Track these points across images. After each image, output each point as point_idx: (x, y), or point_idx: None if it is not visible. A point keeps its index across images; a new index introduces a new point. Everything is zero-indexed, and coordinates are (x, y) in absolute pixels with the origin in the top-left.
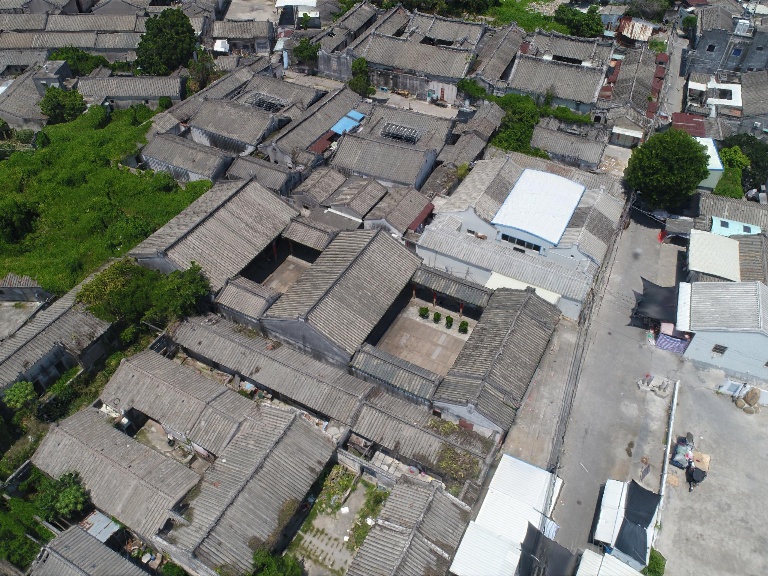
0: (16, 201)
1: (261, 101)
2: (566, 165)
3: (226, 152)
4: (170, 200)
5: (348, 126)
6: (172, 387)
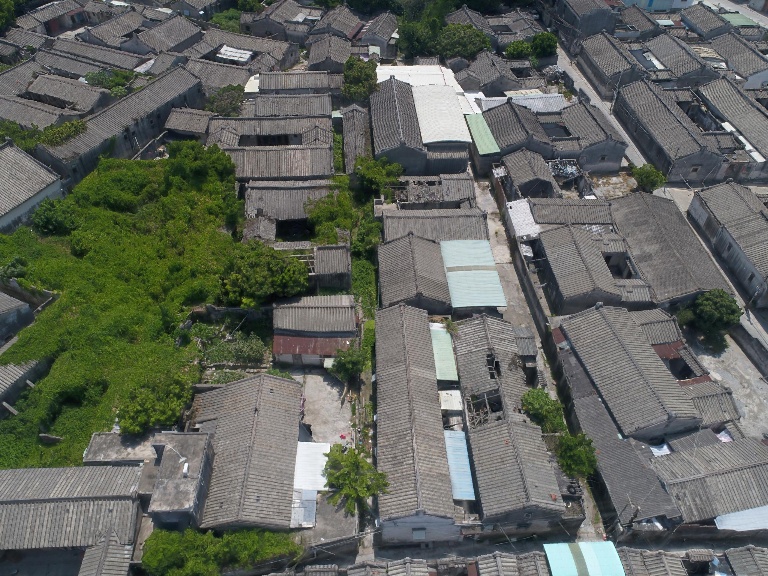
0: (166, 211)
1: None
2: None
3: None
4: (6, 240)
5: None
6: (31, 105)
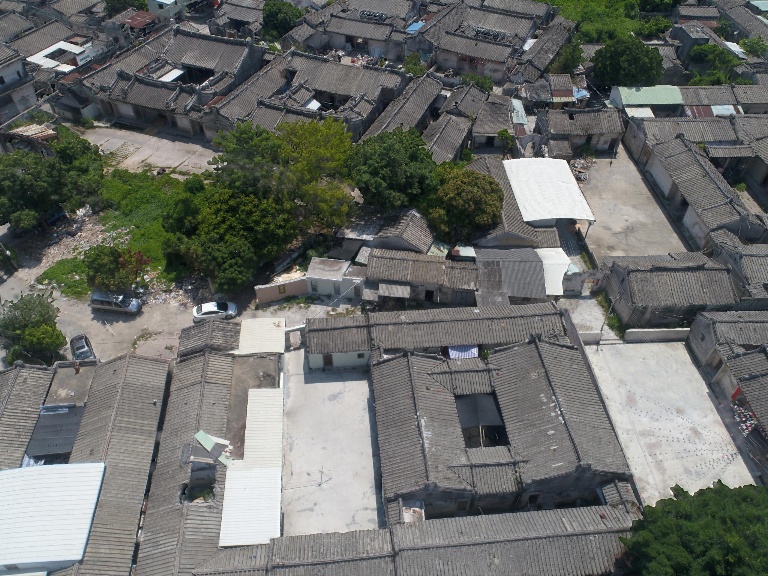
0: None
1: (491, 30)
2: (257, 7)
3: (494, 6)
4: None
5: (414, 27)
6: None
